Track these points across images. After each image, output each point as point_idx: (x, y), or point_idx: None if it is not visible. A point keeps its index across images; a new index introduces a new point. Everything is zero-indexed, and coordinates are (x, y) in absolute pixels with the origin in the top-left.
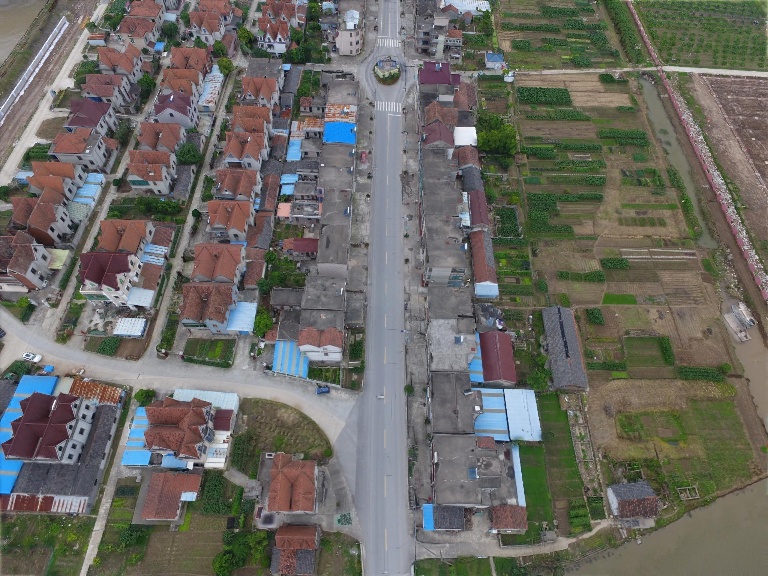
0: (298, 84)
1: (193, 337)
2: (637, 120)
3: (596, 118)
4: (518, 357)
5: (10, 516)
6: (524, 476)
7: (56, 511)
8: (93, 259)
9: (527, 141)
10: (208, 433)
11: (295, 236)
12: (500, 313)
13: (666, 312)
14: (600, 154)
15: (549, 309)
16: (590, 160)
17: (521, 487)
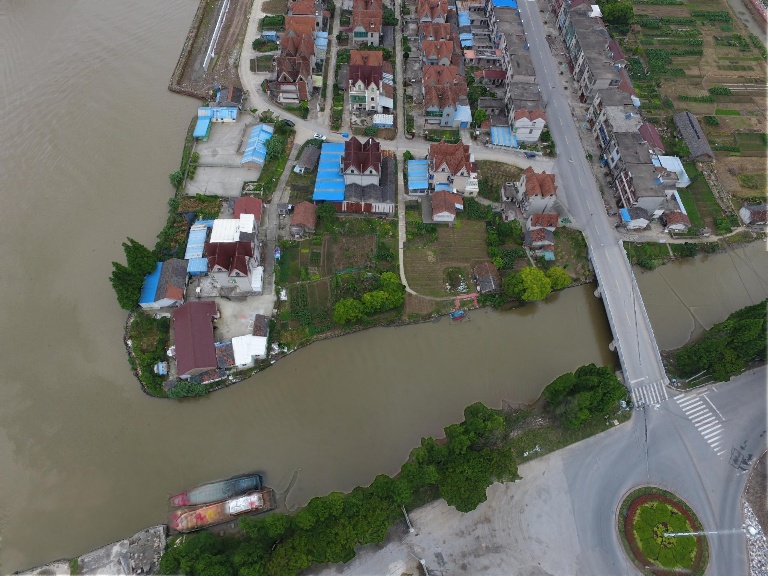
0: None
1: (427, 128)
2: (720, 5)
3: (687, 4)
4: None
5: (341, 218)
6: None
7: (375, 211)
8: (360, 68)
9: (637, 18)
10: None
11: None
12: None
13: (763, 120)
14: (695, 26)
15: (679, 114)
16: None
17: (682, 205)
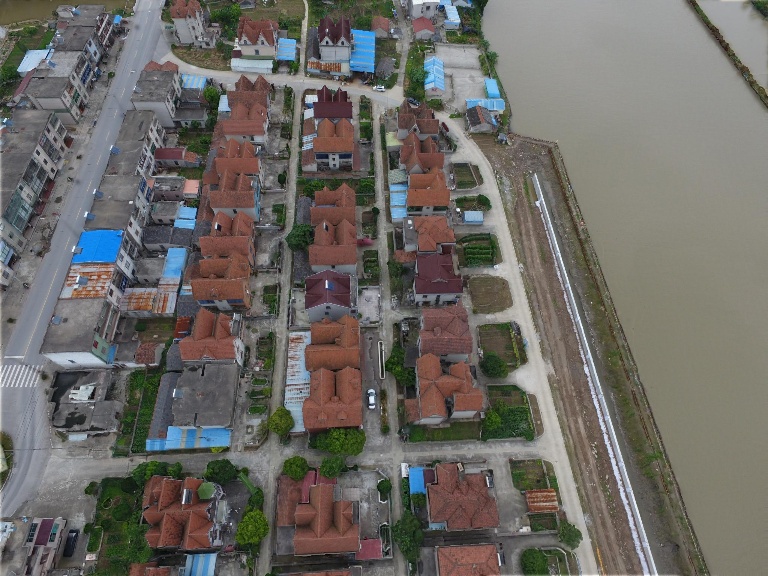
0: None
1: None
2: None
3: None
4: None
5: None
6: None
7: None
8: (339, 99)
9: None
10: None
11: (186, 175)
12: None
13: None
14: None
15: None
16: None
17: None
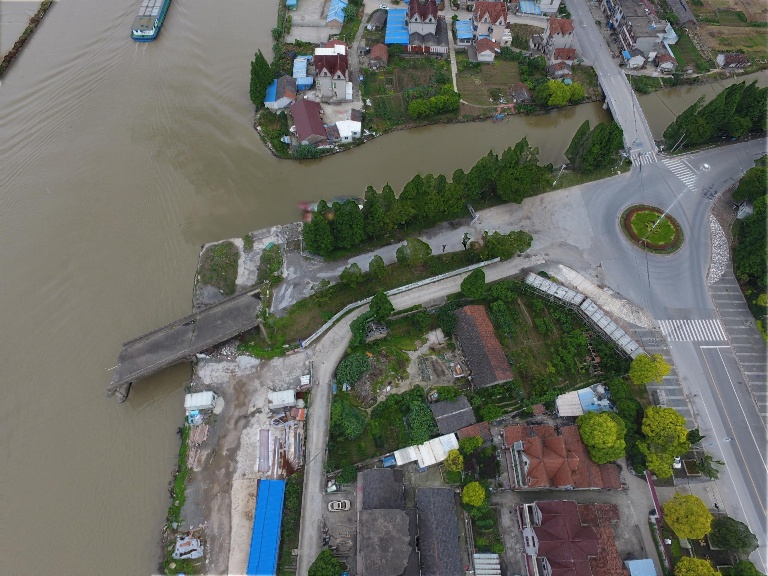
0: None
1: None
2: None
3: None
4: None
5: (406, 58)
6: None
7: (433, 52)
8: None
9: None
10: None
11: None
12: None
13: (739, 2)
14: None
15: None
16: None
17: (671, 52)
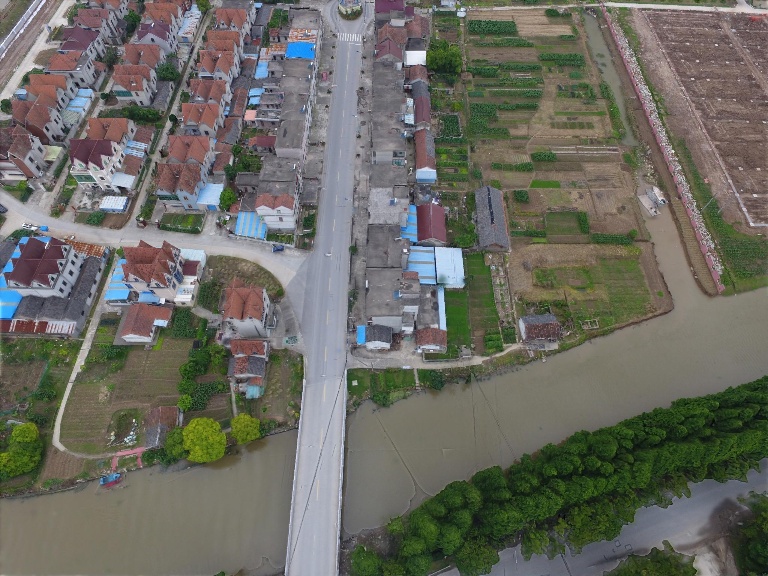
0: (268, 19)
1: (168, 212)
2: (577, 46)
3: (539, 45)
4: (451, 227)
5: (12, 339)
6: (448, 313)
7: (50, 332)
8: (81, 143)
9: (474, 63)
10: (177, 271)
11: None
12: (438, 195)
13: (586, 193)
14: (540, 73)
15: (480, 189)
16: (530, 78)
17: (443, 317)
